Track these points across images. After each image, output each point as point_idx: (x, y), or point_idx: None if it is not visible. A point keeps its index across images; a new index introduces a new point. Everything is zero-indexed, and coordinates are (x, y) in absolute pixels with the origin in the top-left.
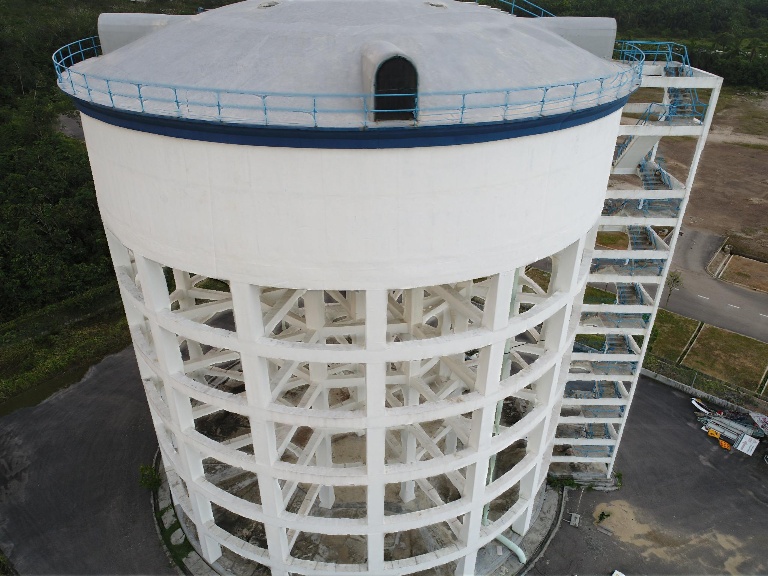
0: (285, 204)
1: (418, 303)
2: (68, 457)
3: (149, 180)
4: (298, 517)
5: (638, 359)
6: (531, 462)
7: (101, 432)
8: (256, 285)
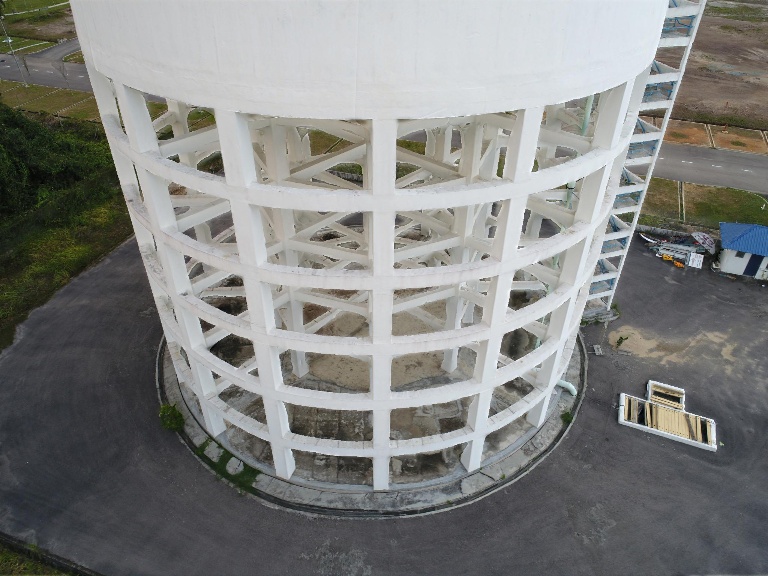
0: (456, 5)
1: (478, 152)
2: (48, 425)
3: None
4: (410, 394)
5: (643, 188)
6: None
7: (75, 389)
8: (407, 119)
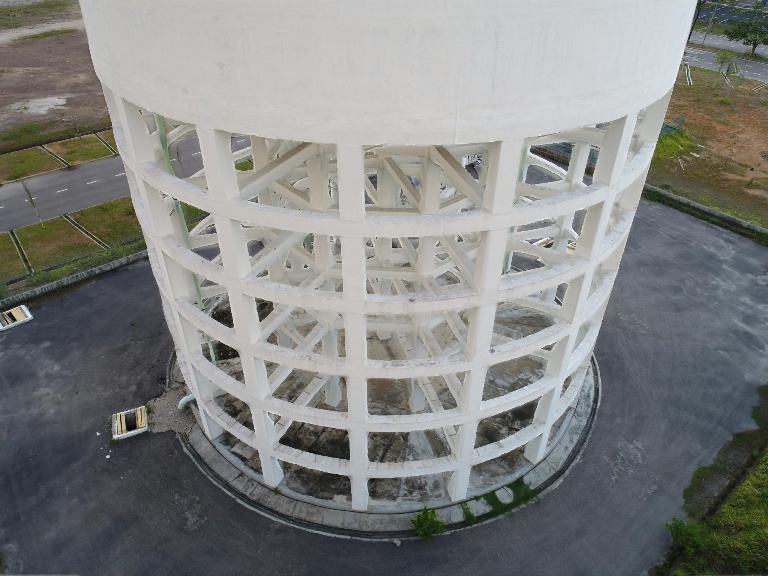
0: None
1: None
2: None
3: (680, 0)
4: None
5: None
6: None
7: None
8: None
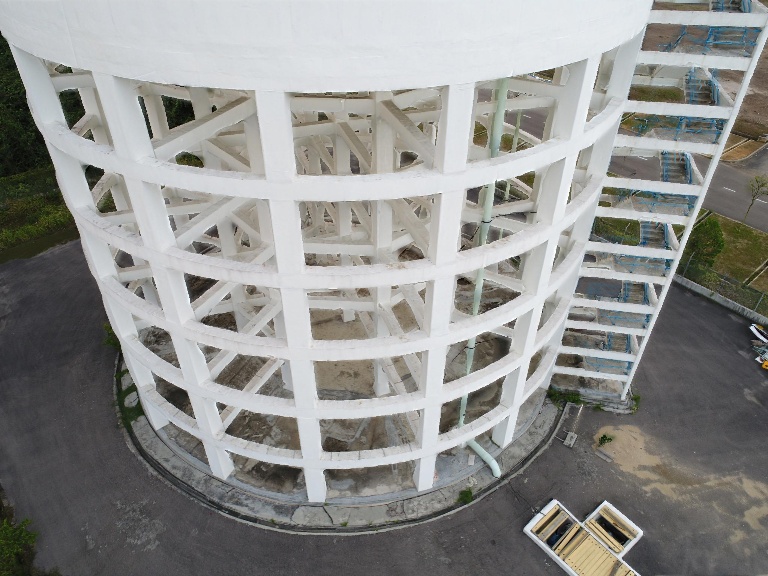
0: None
1: (386, 152)
2: (47, 310)
3: None
4: (221, 388)
5: (674, 256)
6: (511, 363)
7: (85, 289)
8: (120, 77)
